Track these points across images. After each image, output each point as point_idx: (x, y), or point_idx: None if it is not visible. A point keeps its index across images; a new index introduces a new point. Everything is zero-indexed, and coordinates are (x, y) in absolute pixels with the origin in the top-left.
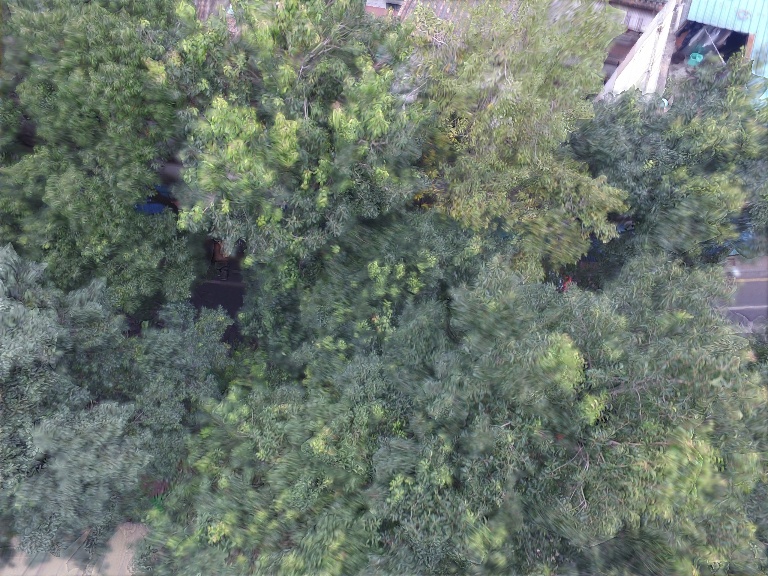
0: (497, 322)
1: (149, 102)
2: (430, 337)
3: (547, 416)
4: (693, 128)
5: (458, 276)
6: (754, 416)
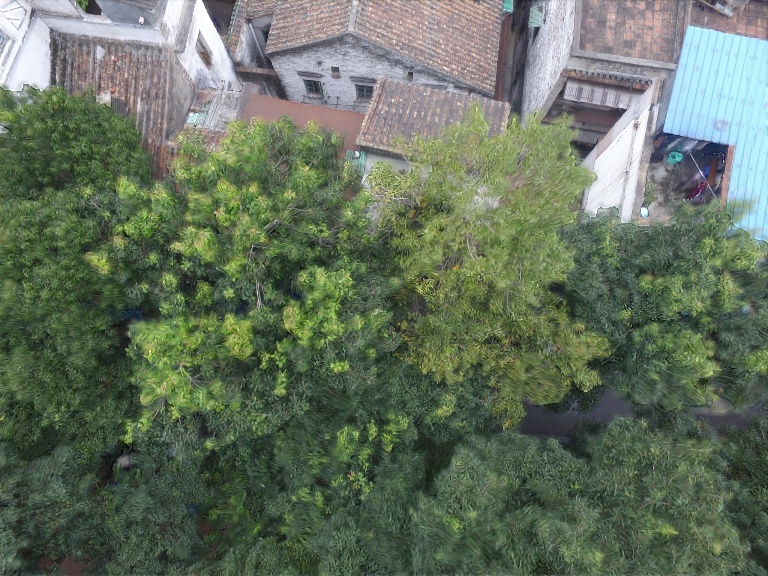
0: (470, 537)
1: (94, 284)
2: (407, 503)
3: None
4: (672, 285)
5: (434, 428)
6: None
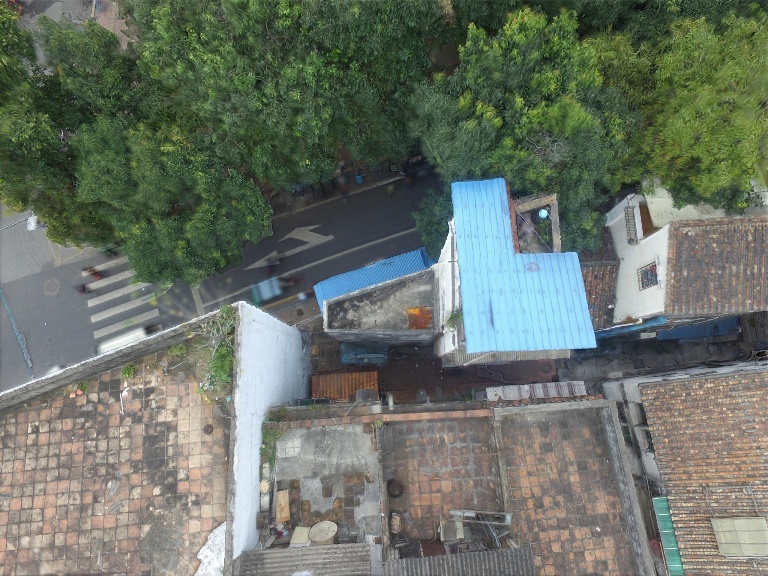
0: None
1: None
2: None
3: None
4: None
5: None
6: None
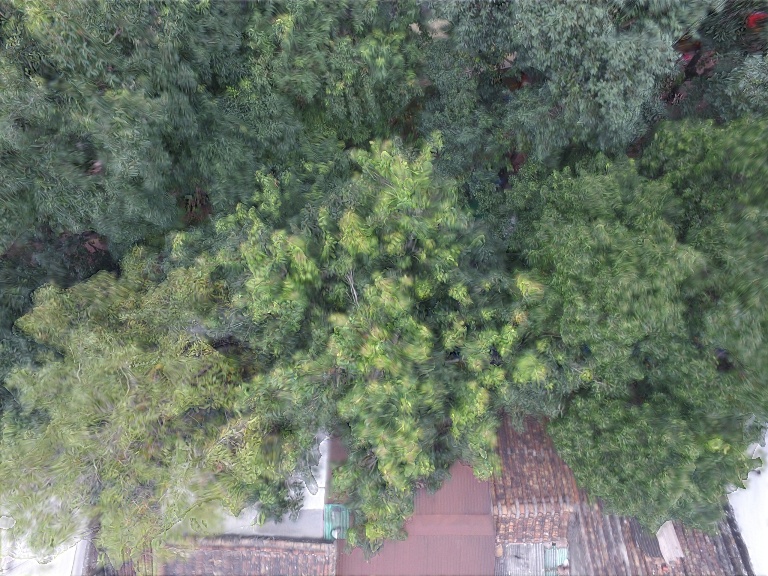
0: None
1: None
2: None
3: None
4: None
5: None
6: None
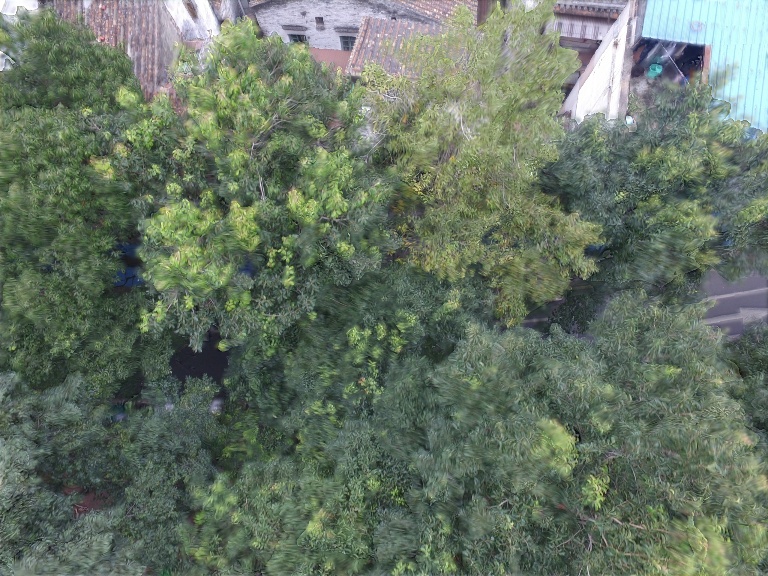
0: (482, 394)
1: (99, 195)
2: (419, 398)
3: (544, 495)
4: (660, 160)
5: (440, 328)
6: (754, 476)
